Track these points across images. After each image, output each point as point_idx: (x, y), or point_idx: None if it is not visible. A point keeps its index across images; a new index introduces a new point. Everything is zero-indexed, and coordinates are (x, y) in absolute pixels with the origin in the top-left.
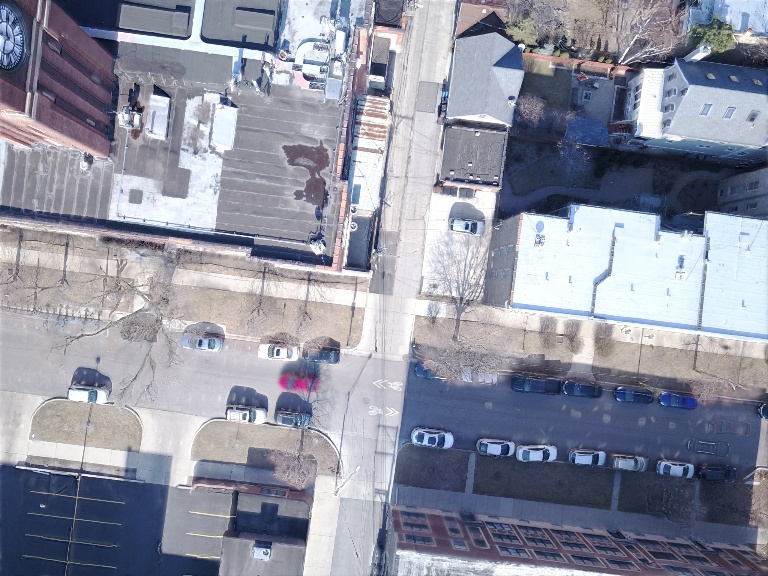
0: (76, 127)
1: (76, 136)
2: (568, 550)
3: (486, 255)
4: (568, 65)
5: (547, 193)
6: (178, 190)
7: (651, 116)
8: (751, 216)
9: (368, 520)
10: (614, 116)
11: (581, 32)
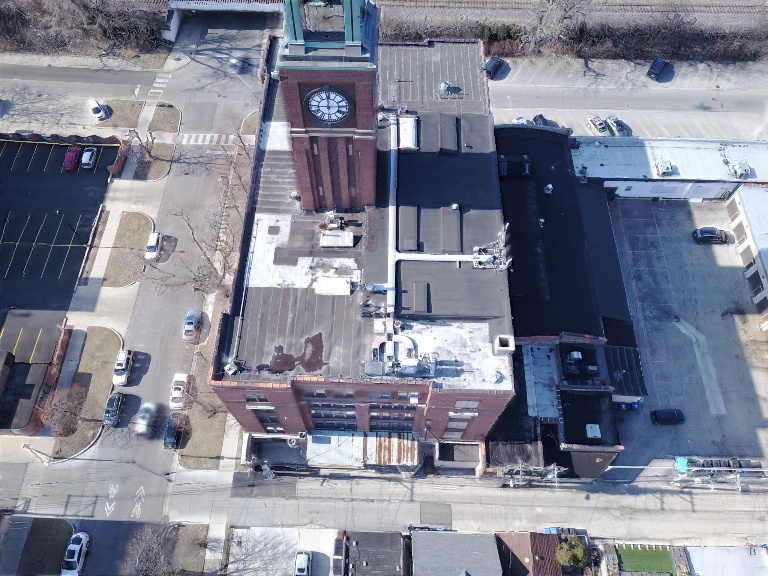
0: (306, 174)
1: (300, 175)
2: None
3: None
4: None
5: None
6: (280, 258)
7: None
8: None
9: None
10: None
11: None
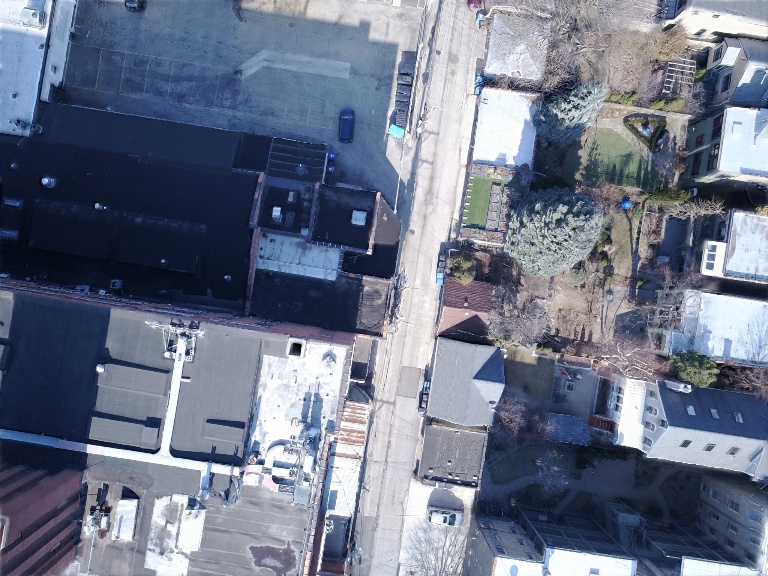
0: None
1: None
2: None
3: (464, 543)
4: (551, 355)
5: (527, 482)
6: None
7: (632, 428)
8: (729, 558)
9: None
10: (597, 406)
11: (565, 322)
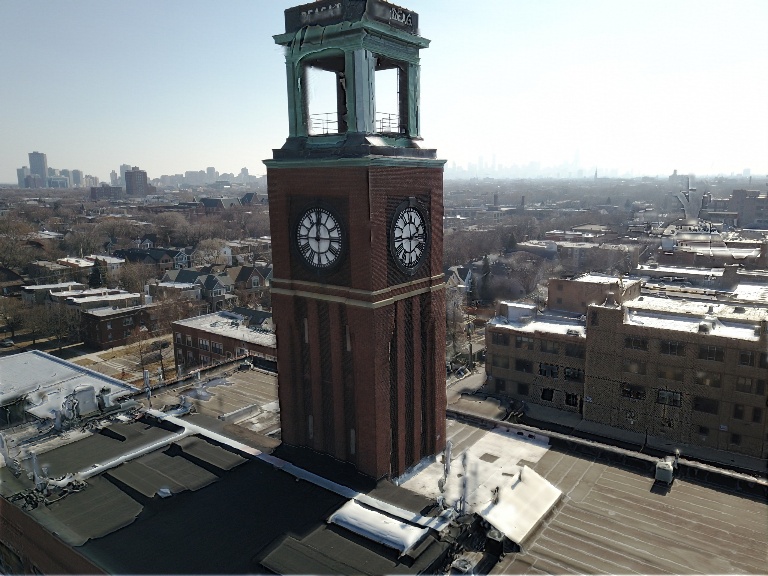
0: None
1: None
2: None
3: None
4: None
5: None
6: None
7: None
8: None
9: None
10: None
11: None
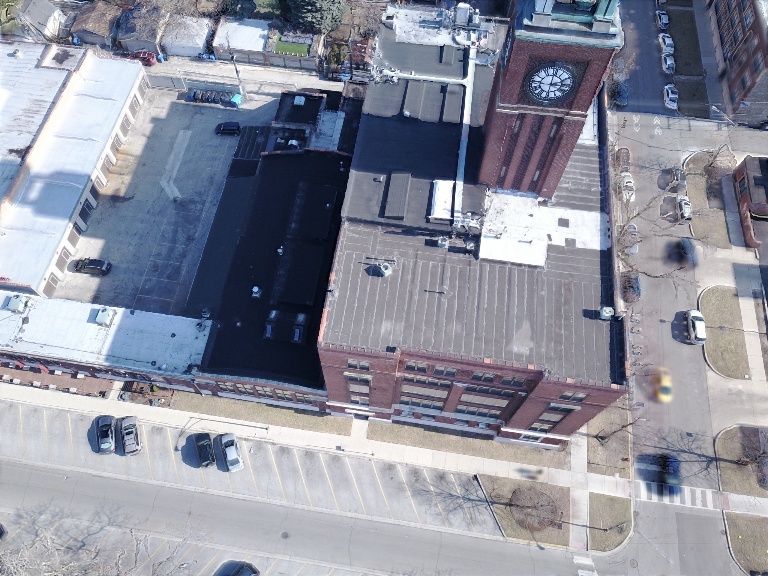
0: None
1: None
2: (736, 1)
3: None
4: None
5: None
6: None
7: None
8: None
9: (744, 134)
10: (430, 4)
11: None
